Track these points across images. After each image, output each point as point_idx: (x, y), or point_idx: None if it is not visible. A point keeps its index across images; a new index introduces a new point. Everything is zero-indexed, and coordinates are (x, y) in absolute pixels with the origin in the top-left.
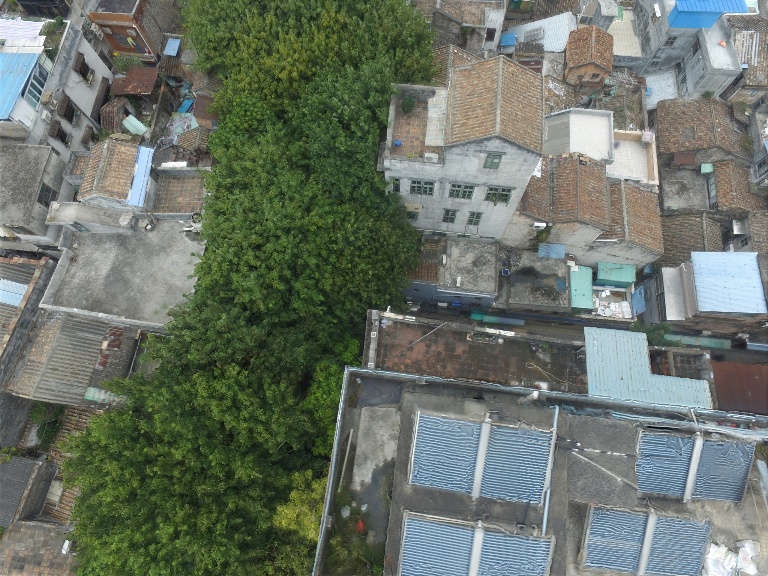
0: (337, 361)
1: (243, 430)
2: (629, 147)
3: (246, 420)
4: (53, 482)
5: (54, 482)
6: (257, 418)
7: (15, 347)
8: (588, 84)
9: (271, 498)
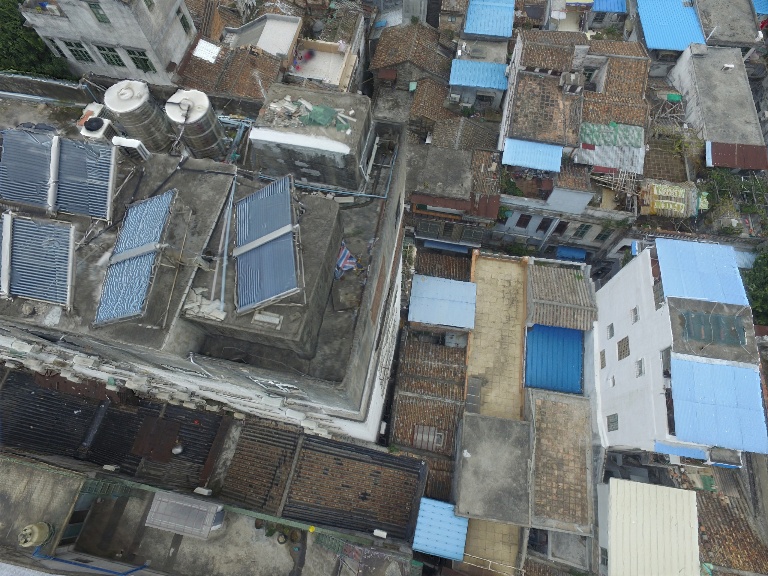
0: None
1: None
2: (333, 58)
3: None
4: None
5: None
6: None
7: None
8: (314, 6)
9: None
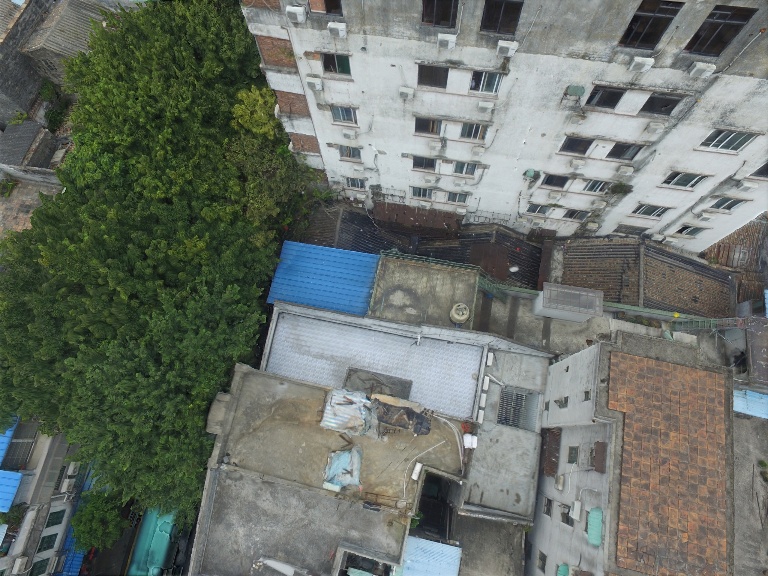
0: None
1: (211, 45)
2: None
3: (213, 33)
4: (57, 151)
5: (57, 151)
6: (223, 41)
7: (30, 19)
8: None
9: (231, 105)
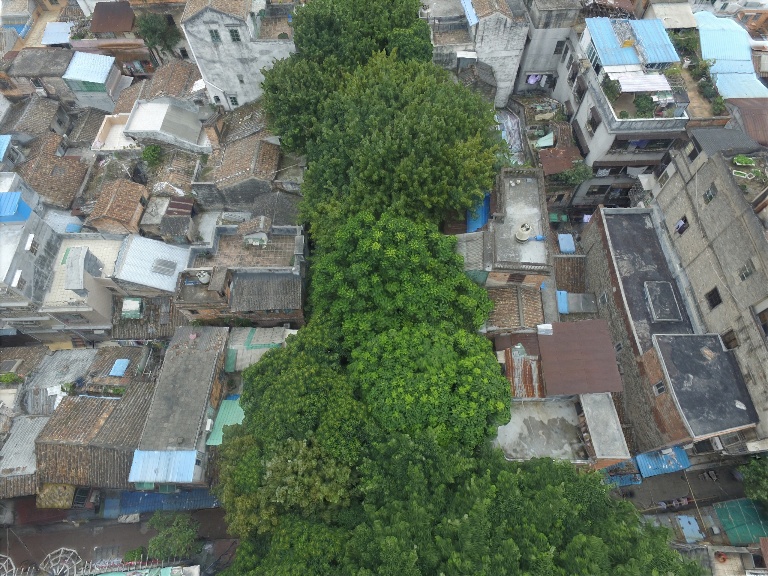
0: None
1: None
2: None
3: None
4: None
5: None
6: None
7: None
8: None
9: None
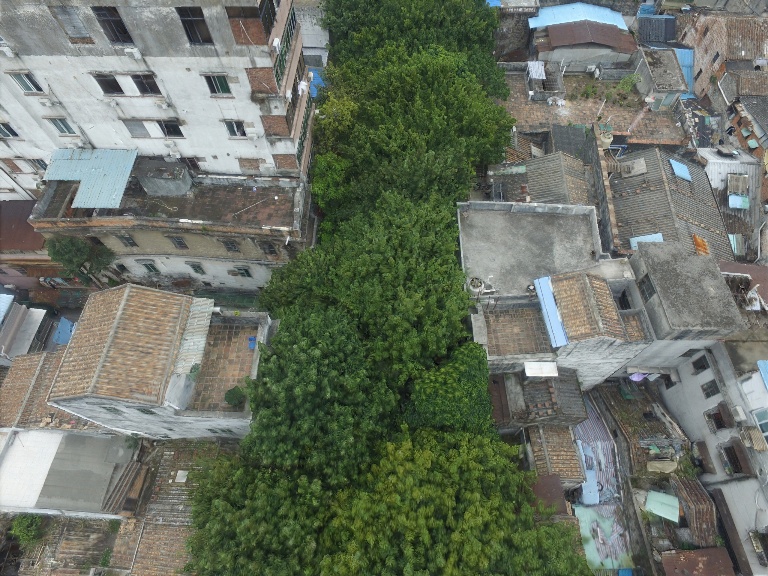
0: (334, 214)
1: None
2: None
3: None
4: None
5: None
6: None
7: None
8: None
9: None
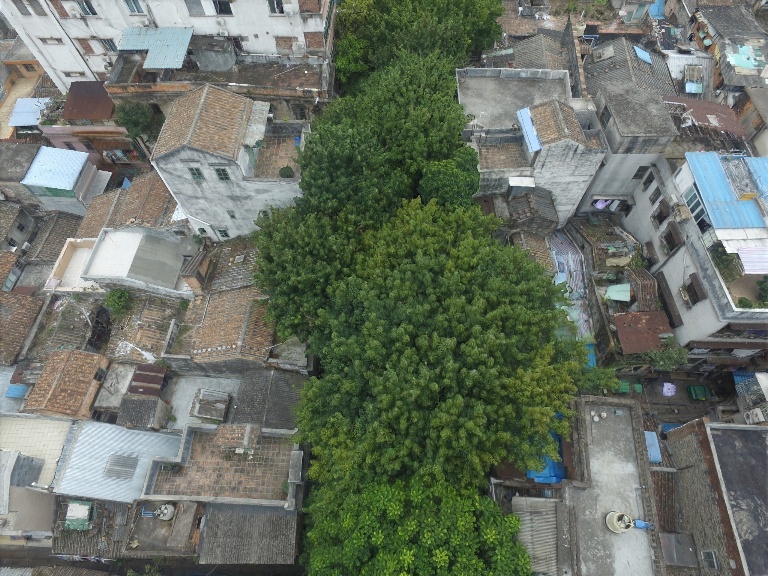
0: (354, 87)
1: None
2: None
3: None
4: None
5: None
6: None
7: None
8: None
9: None
